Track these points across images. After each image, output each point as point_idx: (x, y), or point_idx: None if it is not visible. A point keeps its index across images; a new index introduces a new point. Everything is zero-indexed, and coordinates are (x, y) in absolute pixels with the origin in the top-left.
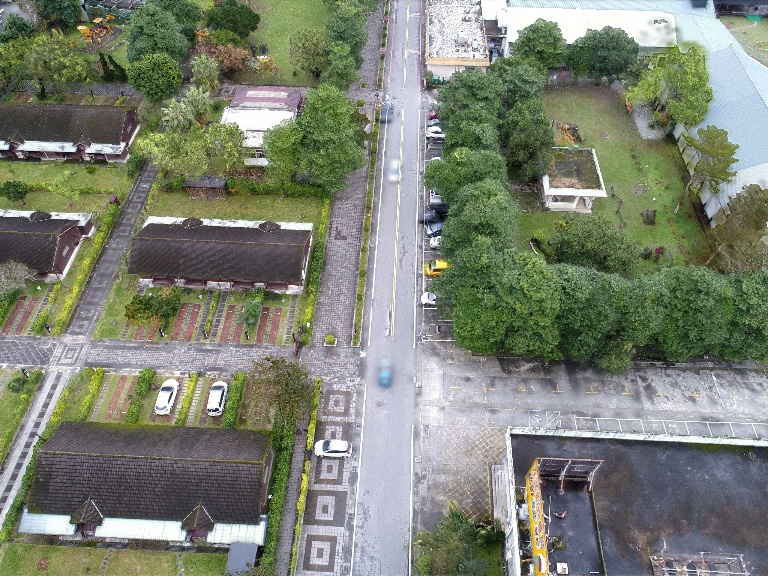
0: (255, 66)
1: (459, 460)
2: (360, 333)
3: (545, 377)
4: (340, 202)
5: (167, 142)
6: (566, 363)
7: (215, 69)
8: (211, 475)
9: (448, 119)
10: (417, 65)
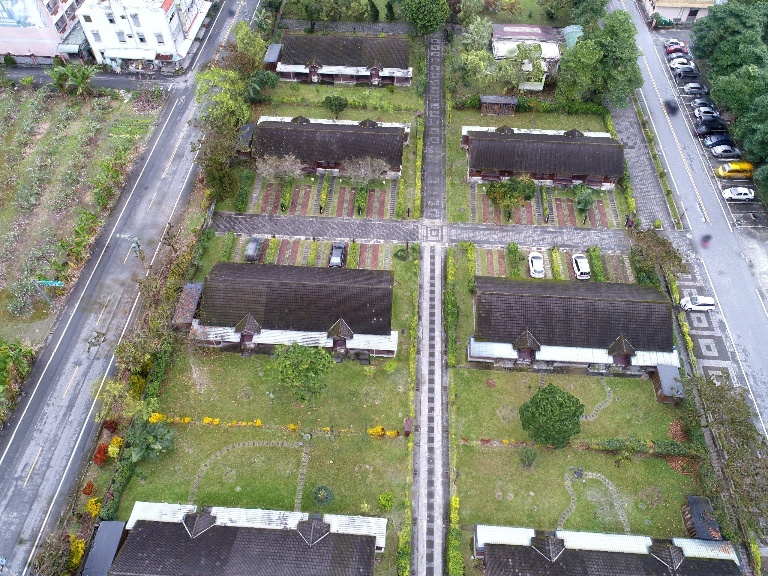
0: (502, 6)
1: None
2: (680, 220)
3: None
4: (616, 119)
5: (486, 58)
6: None
7: None
8: (628, 312)
9: (714, 46)
10: (636, 9)
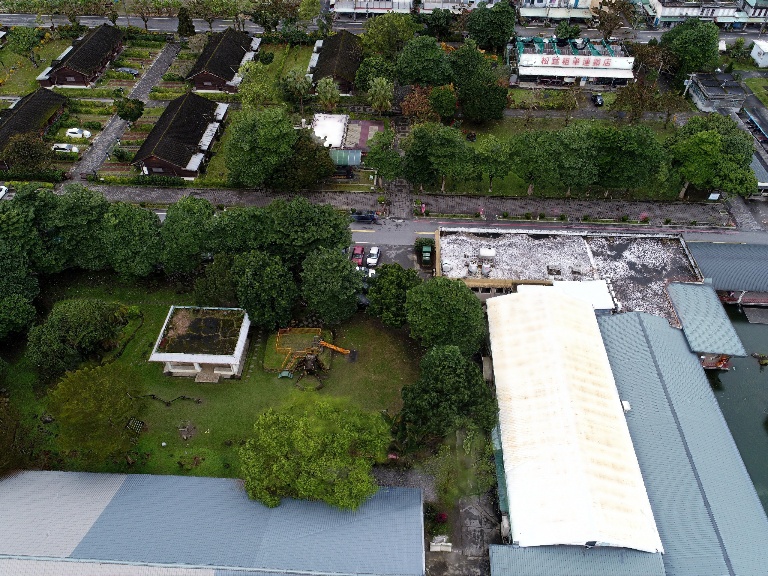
0: None
1: None
2: None
3: None
4: (236, 194)
5: (252, 73)
6: None
7: (386, 97)
8: None
9: None
10: None
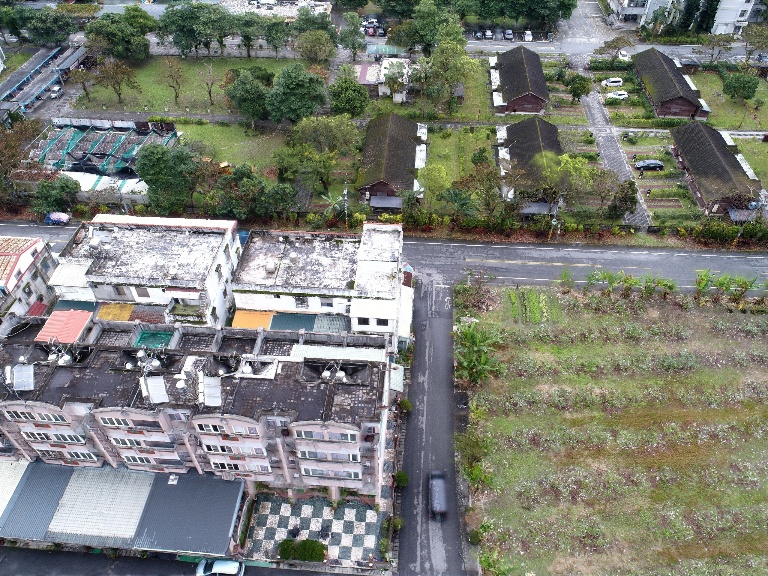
0: None
1: (614, 35)
2: None
3: None
4: None
5: None
6: None
7: None
8: (664, 60)
9: None
10: None
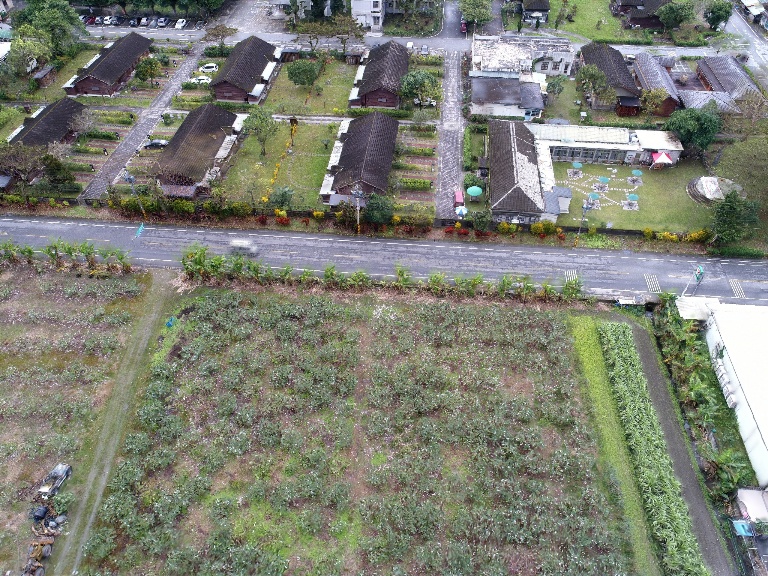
0: None
1: None
2: None
3: (235, 9)
4: None
5: None
6: (230, 5)
7: None
8: (253, 47)
9: None
10: None
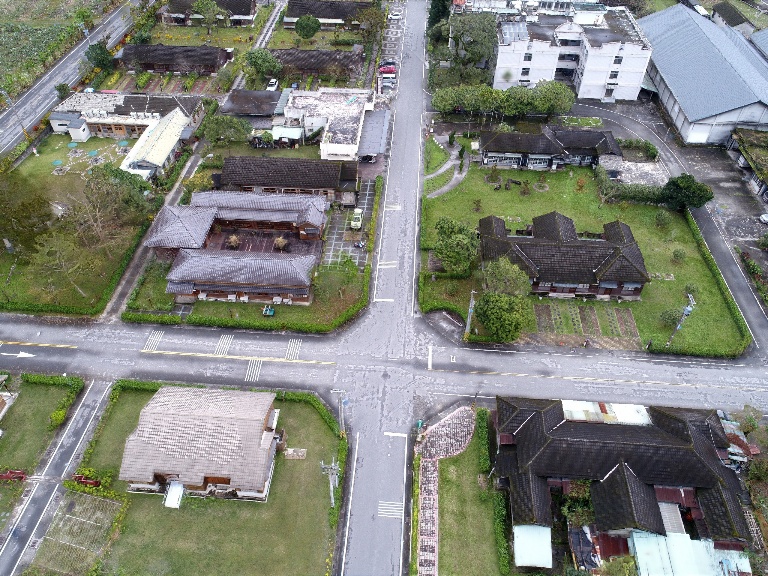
0: None
1: None
2: None
3: None
4: None
5: None
6: None
7: None
8: (353, 6)
9: None
10: None
